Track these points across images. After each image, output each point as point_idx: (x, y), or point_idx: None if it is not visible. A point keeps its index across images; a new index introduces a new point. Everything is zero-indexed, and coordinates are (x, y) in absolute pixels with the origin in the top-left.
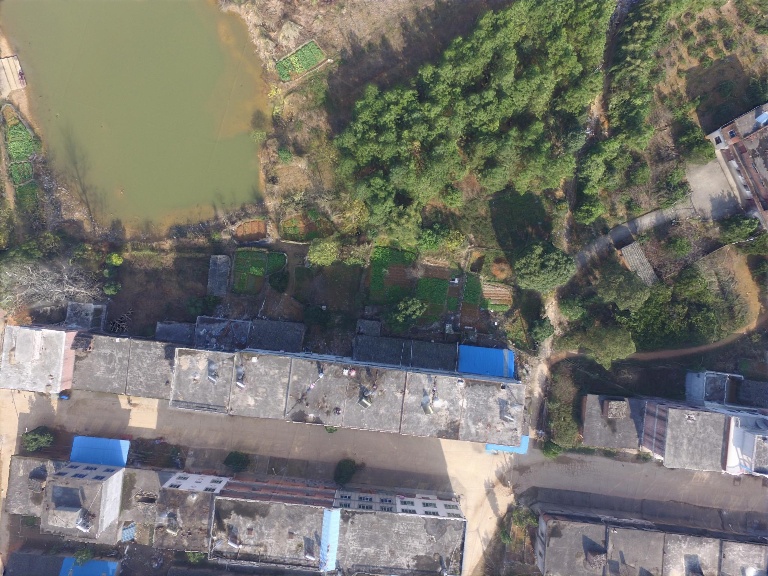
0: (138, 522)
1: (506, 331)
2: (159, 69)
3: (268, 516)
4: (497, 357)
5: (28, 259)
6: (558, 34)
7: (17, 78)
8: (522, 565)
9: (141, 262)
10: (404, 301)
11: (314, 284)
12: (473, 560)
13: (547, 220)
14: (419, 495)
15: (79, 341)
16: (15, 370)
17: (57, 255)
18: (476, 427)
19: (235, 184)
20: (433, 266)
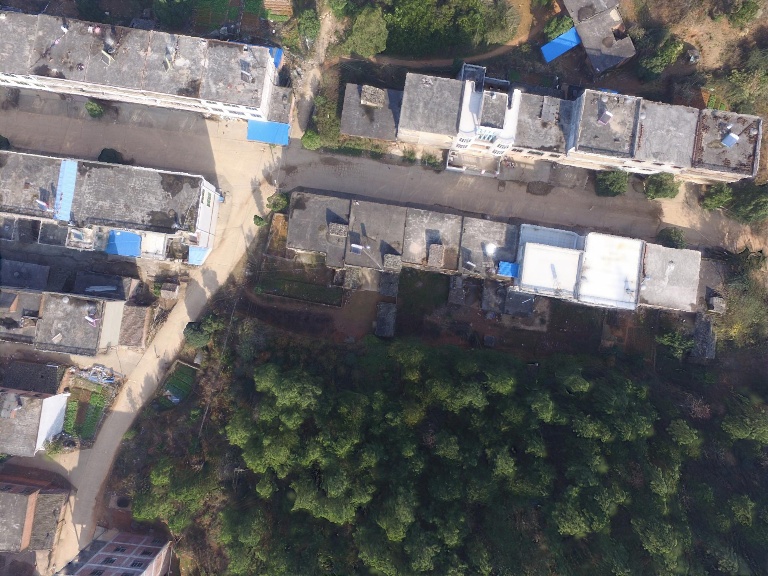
0: None
1: (282, 38)
2: None
3: (5, 166)
4: None
5: None
6: None
7: None
8: (283, 261)
9: None
10: None
11: None
12: (236, 256)
13: None
14: None
15: None
16: None
17: None
18: (217, 87)
19: None
20: None
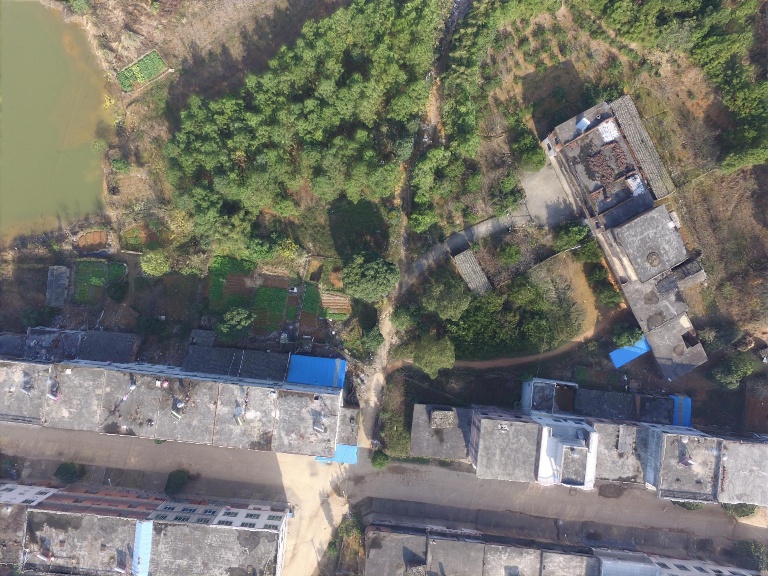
0: None
1: (343, 340)
2: (4, 80)
3: (81, 528)
4: (328, 367)
5: None
6: (382, 42)
7: None
8: (356, 575)
9: None
10: (231, 311)
11: (154, 294)
12: (307, 571)
13: (385, 228)
14: (252, 506)
15: None
16: None
17: None
18: (289, 438)
19: (79, 194)
20: (272, 275)
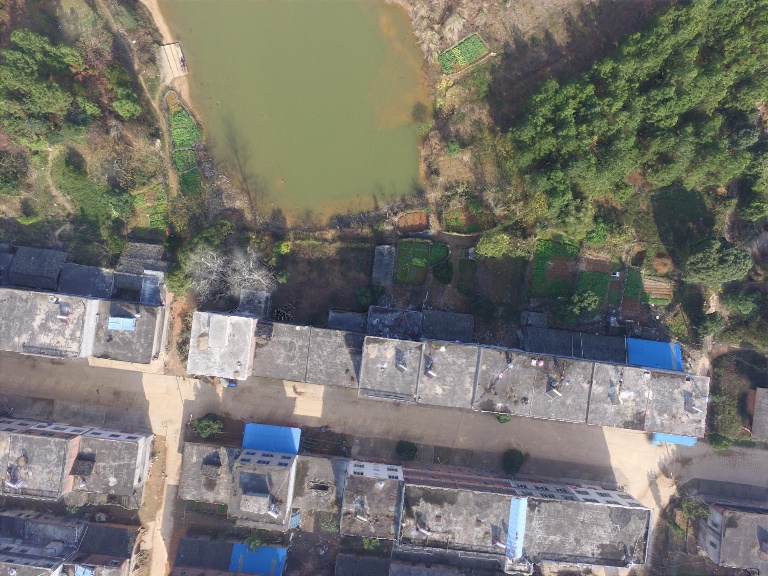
0: (303, 509)
1: (668, 325)
2: (320, 59)
3: (456, 504)
4: (665, 350)
5: (209, 246)
6: (735, 32)
7: (179, 65)
8: (684, 555)
9: (306, 251)
10: (577, 293)
11: (476, 276)
12: None
13: (709, 216)
14: (584, 485)
15: (261, 328)
16: (203, 356)
17: (227, 243)
18: (661, 418)
19: (395, 175)
20: (595, 260)
